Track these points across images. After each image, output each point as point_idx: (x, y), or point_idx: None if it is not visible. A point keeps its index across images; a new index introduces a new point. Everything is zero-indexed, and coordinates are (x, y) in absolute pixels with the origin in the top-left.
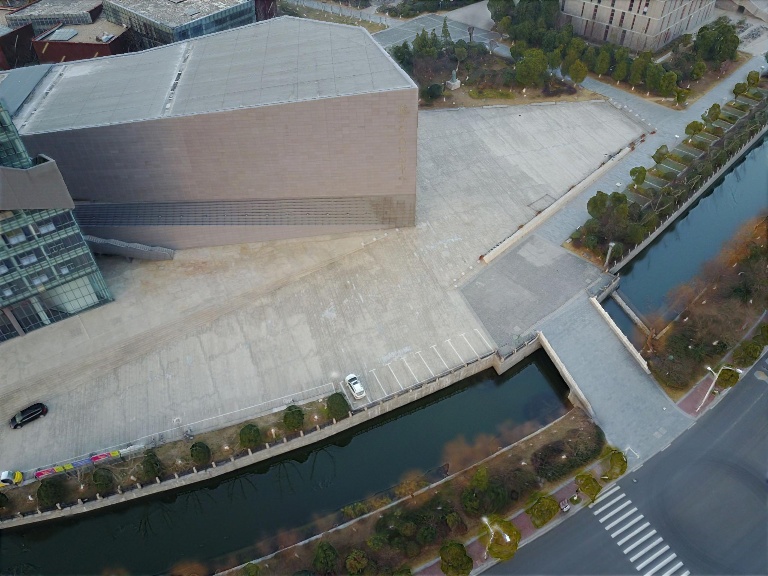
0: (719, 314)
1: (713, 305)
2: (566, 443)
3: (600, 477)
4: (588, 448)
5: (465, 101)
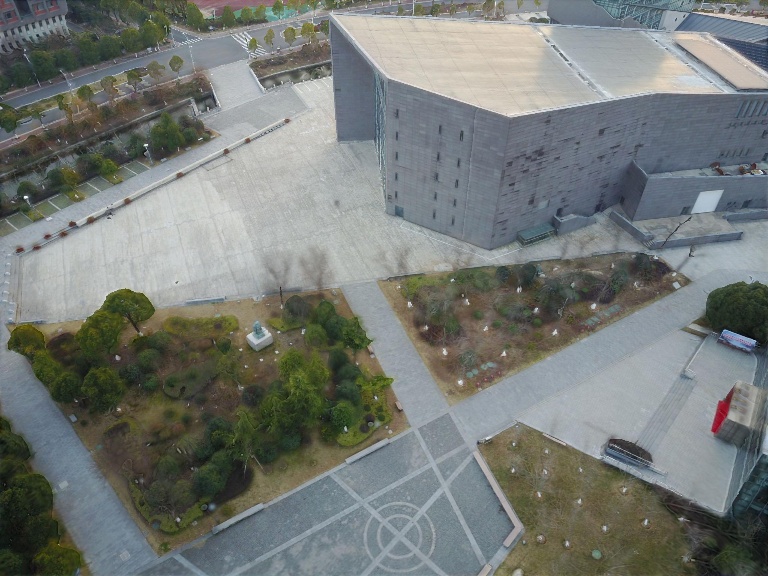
0: (148, 92)
1: (140, 110)
2: (269, 63)
3: (259, 58)
4: (260, 62)
5: (249, 310)
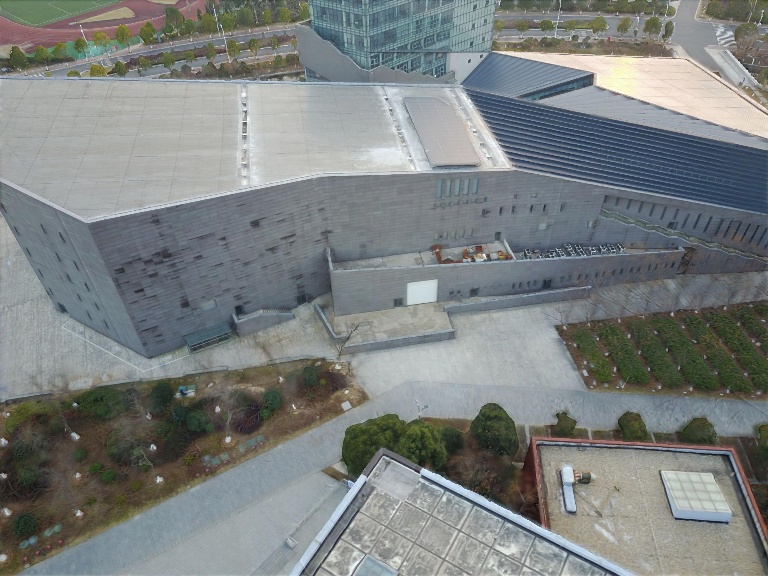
0: None
1: None
2: None
3: None
4: None
5: None
